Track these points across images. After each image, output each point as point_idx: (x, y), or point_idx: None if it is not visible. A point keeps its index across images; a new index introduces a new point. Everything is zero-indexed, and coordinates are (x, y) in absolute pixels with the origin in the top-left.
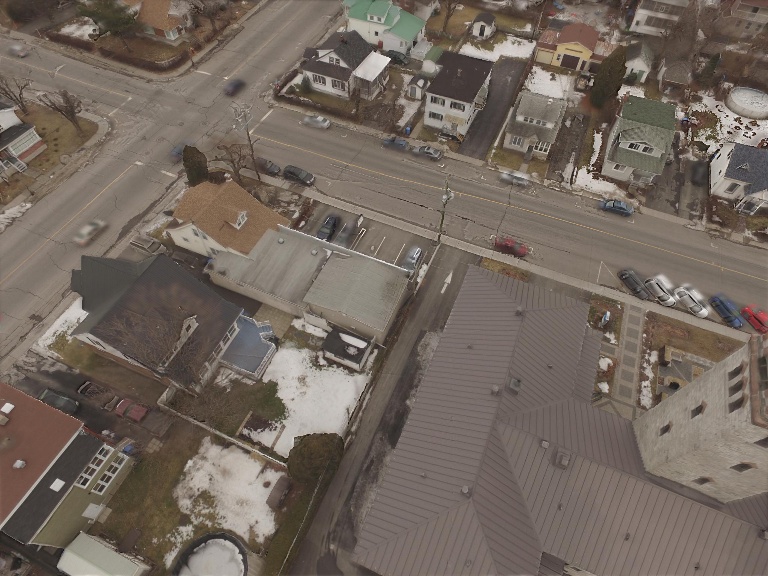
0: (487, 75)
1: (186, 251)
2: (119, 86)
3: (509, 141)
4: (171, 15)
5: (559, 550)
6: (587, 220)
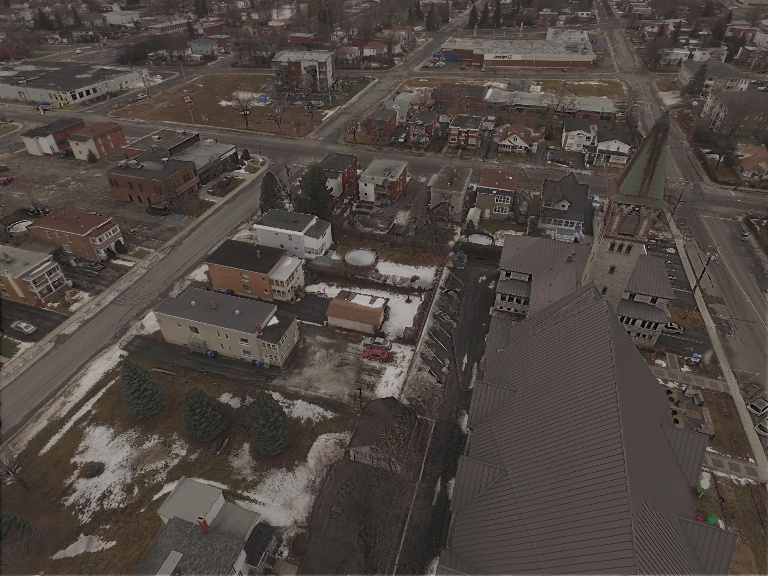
0: None
1: (602, 211)
2: (686, 174)
3: None
4: (759, 166)
5: None
6: None
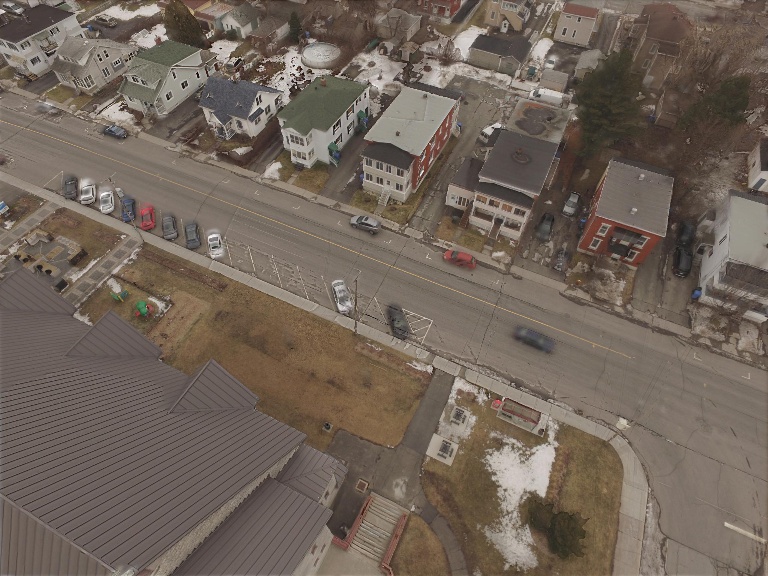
0: (55, 22)
1: None
2: None
3: (60, 78)
4: None
5: None
6: (82, 141)
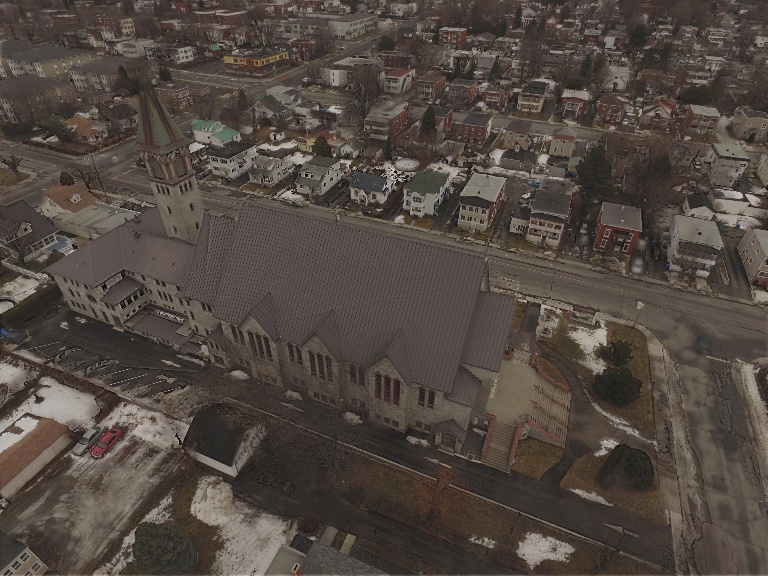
0: (247, 149)
1: None
2: (51, 161)
3: (252, 178)
4: (93, 129)
5: (129, 267)
6: None
